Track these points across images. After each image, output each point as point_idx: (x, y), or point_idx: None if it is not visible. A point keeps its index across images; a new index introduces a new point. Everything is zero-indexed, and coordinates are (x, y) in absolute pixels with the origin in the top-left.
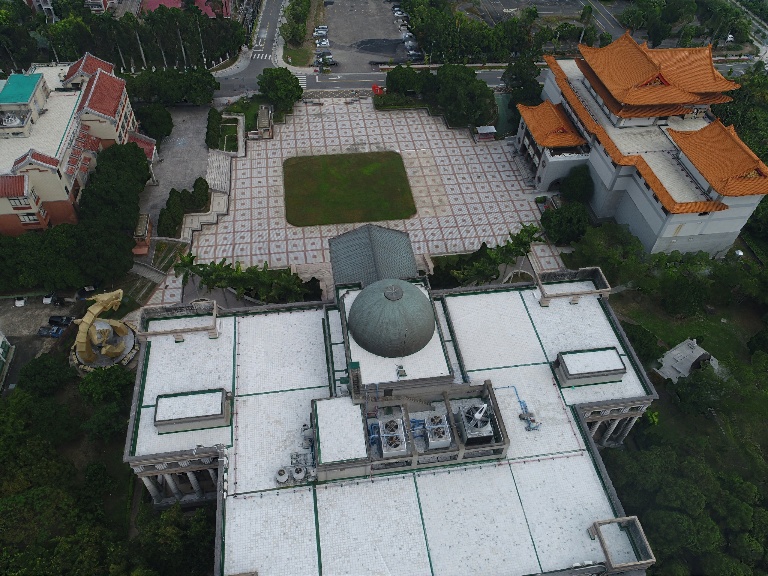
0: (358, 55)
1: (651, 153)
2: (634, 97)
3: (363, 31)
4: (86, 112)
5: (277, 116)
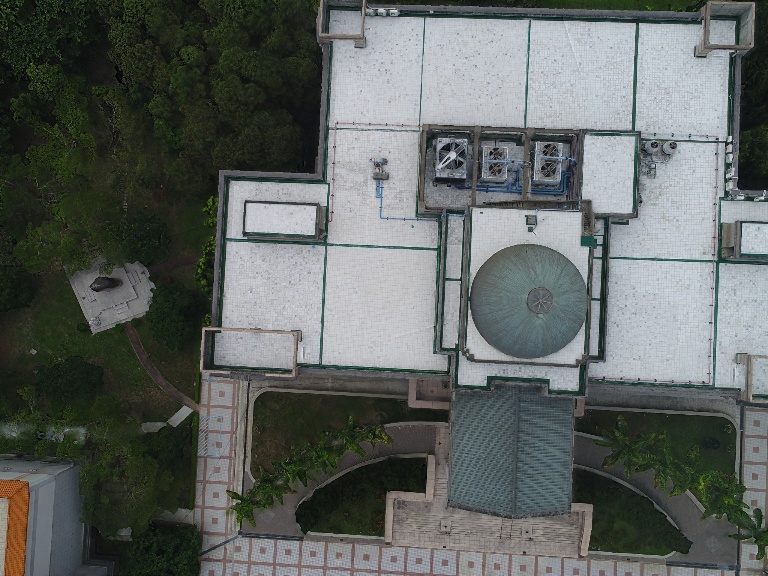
0: None
1: None
2: None
3: None
4: None
5: None
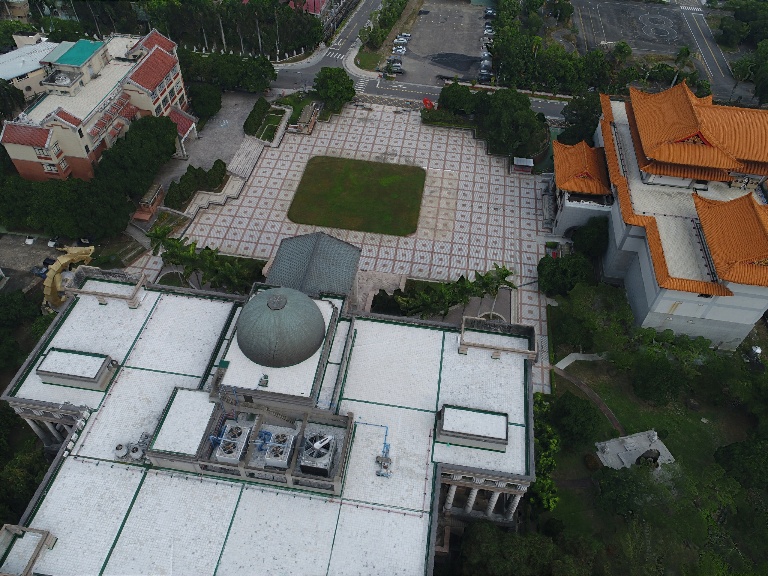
0: (429, 67)
1: (671, 217)
2: (664, 153)
3: (445, 44)
4: (128, 82)
5: (323, 114)
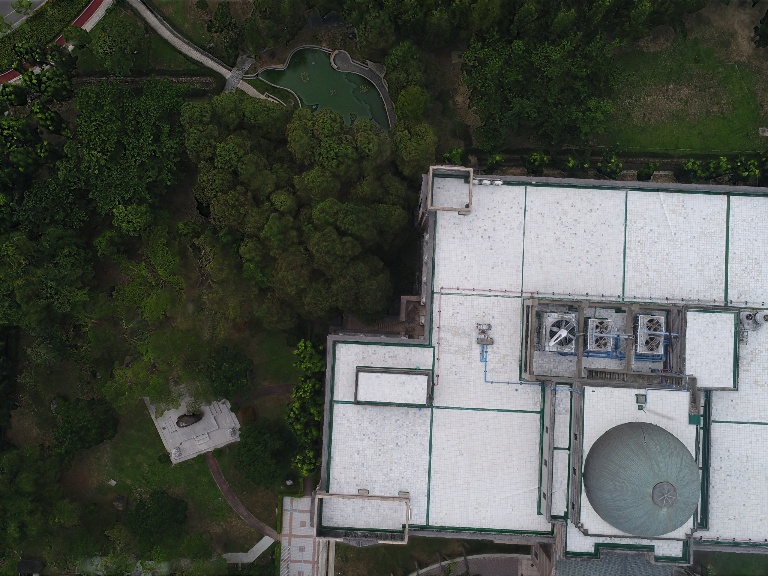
0: None
1: None
2: None
3: None
4: None
5: None
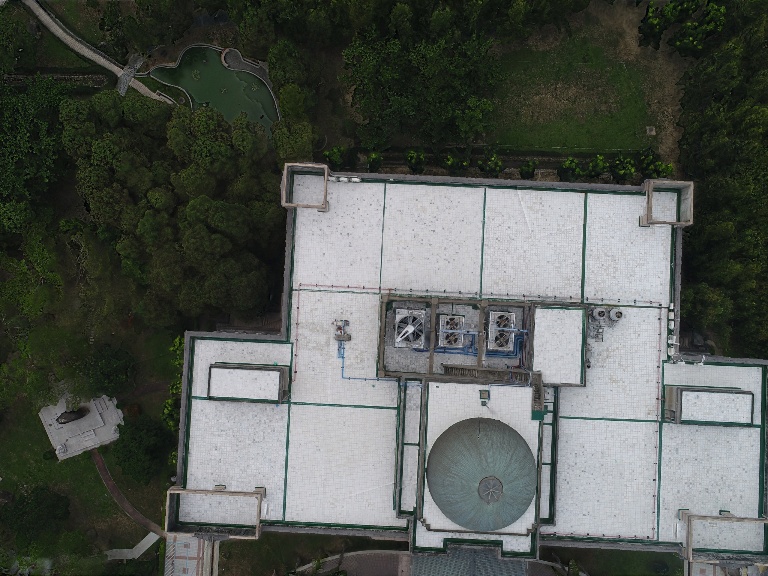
0: None
1: None
2: None
3: None
4: None
5: None
